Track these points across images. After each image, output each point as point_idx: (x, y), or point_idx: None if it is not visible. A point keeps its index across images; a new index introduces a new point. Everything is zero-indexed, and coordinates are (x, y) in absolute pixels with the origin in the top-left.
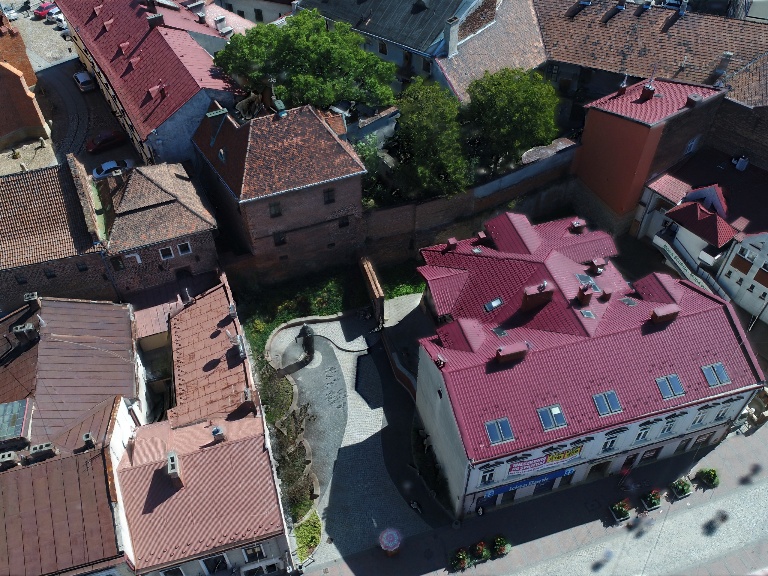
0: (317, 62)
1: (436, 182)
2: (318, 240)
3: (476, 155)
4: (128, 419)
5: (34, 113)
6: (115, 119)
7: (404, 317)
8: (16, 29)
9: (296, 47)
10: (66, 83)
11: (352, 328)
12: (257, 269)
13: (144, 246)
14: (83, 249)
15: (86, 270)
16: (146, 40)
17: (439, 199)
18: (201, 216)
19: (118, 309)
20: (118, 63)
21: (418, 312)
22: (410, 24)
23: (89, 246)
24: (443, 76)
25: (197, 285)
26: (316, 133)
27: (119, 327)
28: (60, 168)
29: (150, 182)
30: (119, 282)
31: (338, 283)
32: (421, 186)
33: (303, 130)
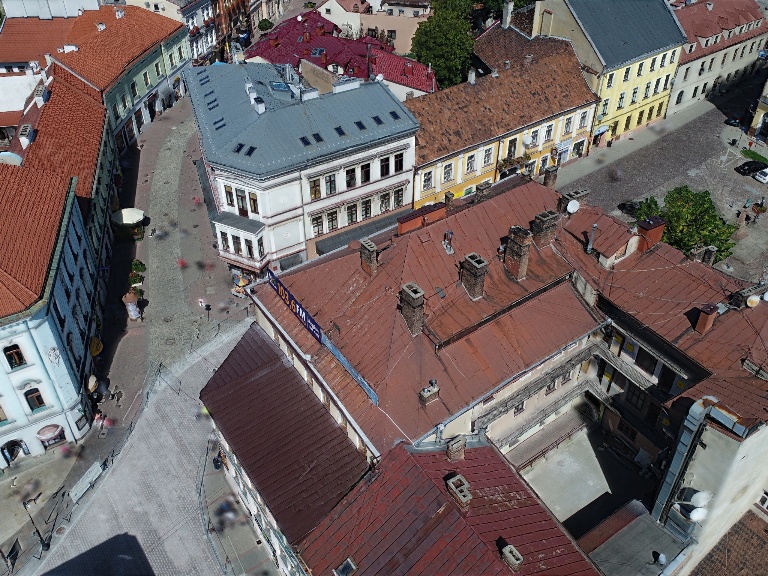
0: None
1: None
2: None
3: None
4: (378, 5)
5: None
6: None
7: None
8: None
9: None
10: None
11: None
12: None
13: None
14: None
15: None
16: None
17: None
18: None
19: (427, 1)
20: None
21: None
22: None
23: None
24: None
25: None
26: None
27: (417, 0)
28: None
29: None
30: None
31: None
32: None
33: None
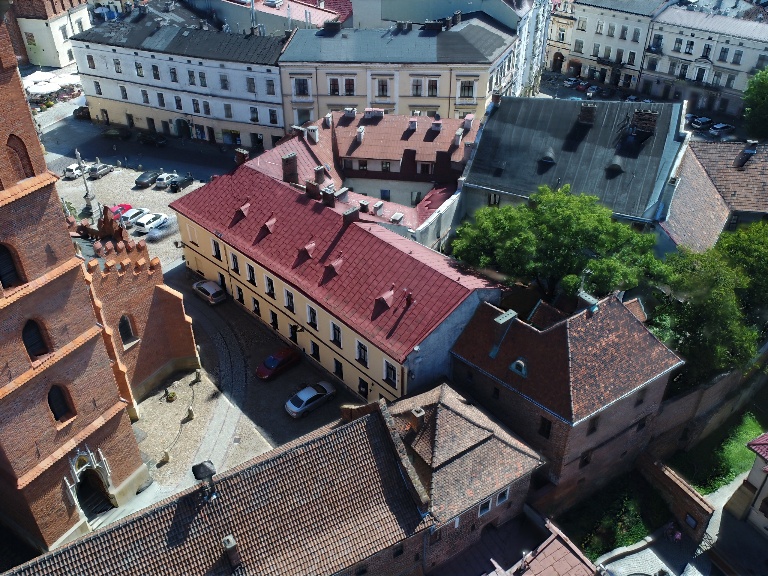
0: (604, 243)
1: (730, 360)
2: (616, 451)
3: (750, 323)
4: None
5: (188, 341)
6: (269, 333)
7: (719, 528)
8: (143, 242)
9: (583, 229)
10: (184, 296)
11: (670, 555)
12: (553, 501)
13: (473, 506)
14: (411, 527)
15: (400, 554)
16: (343, 239)
17: (723, 378)
18: (522, 450)
19: None
20: (306, 269)
21: (728, 518)
22: (610, 190)
23: (417, 521)
24: (670, 240)
25: (506, 540)
26: (628, 325)
27: None
28: (367, 420)
29: (459, 417)
30: (428, 559)
31: (631, 499)
32: (709, 367)
33: (615, 324)
